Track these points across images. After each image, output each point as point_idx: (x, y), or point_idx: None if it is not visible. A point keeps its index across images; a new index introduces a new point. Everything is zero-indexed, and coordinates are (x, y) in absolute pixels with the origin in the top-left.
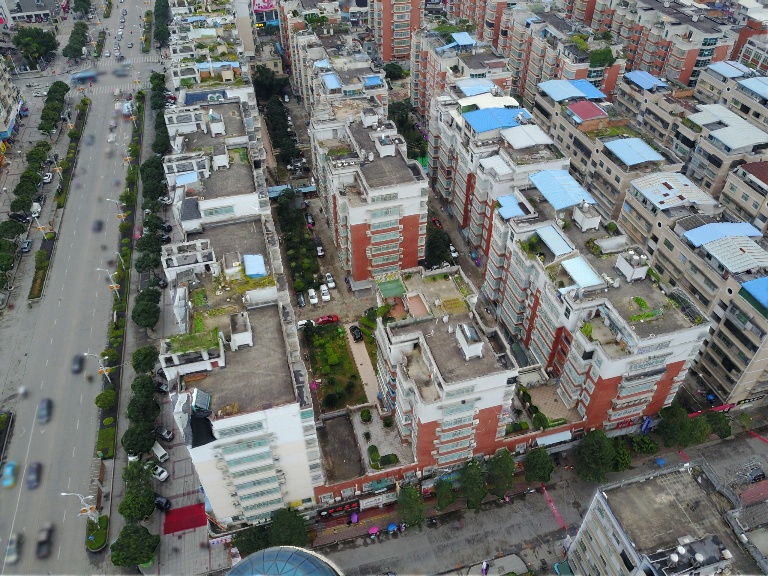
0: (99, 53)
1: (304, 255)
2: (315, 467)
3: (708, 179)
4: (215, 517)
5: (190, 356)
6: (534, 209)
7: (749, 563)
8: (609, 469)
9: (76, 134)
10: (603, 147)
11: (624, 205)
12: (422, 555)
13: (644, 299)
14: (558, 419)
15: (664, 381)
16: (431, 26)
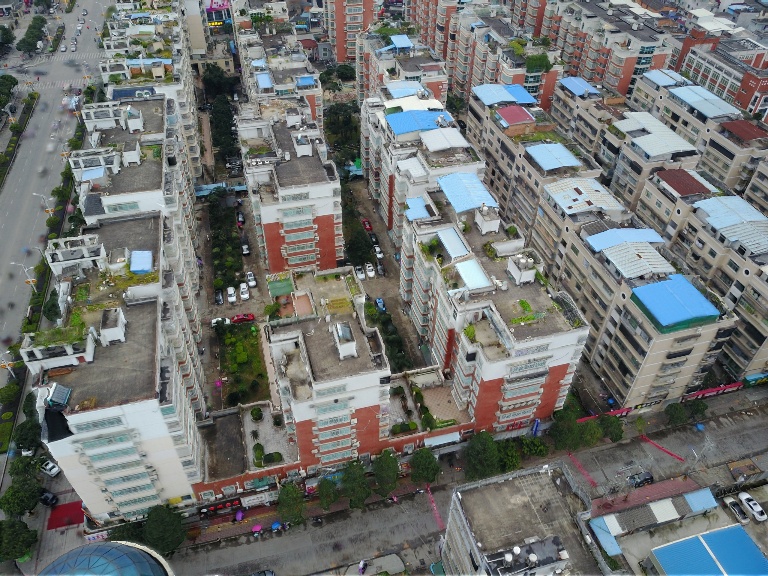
0: (55, 48)
1: (229, 253)
2: (188, 464)
3: (630, 186)
4: (90, 513)
5: (55, 351)
6: (439, 211)
7: (590, 564)
8: (497, 471)
9: (18, 128)
10: (525, 152)
11: (538, 209)
12: (303, 554)
13: (529, 302)
14: (448, 420)
15: (551, 384)
16: (374, 28)
